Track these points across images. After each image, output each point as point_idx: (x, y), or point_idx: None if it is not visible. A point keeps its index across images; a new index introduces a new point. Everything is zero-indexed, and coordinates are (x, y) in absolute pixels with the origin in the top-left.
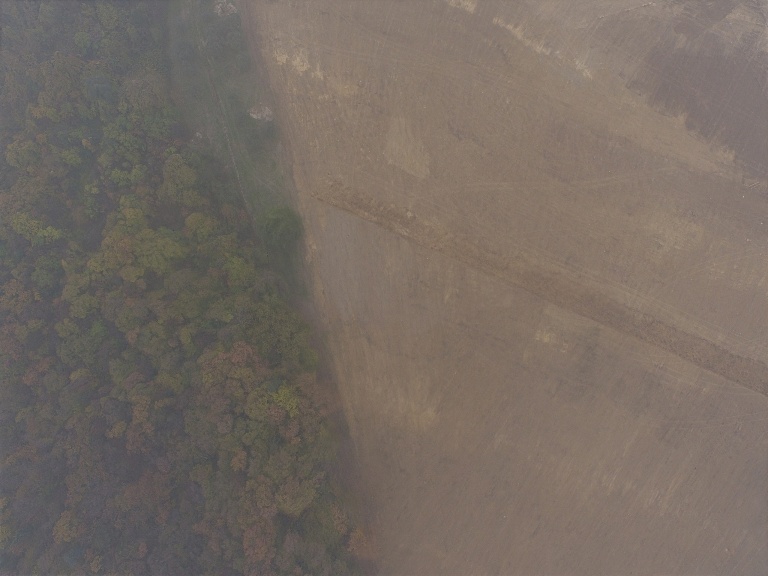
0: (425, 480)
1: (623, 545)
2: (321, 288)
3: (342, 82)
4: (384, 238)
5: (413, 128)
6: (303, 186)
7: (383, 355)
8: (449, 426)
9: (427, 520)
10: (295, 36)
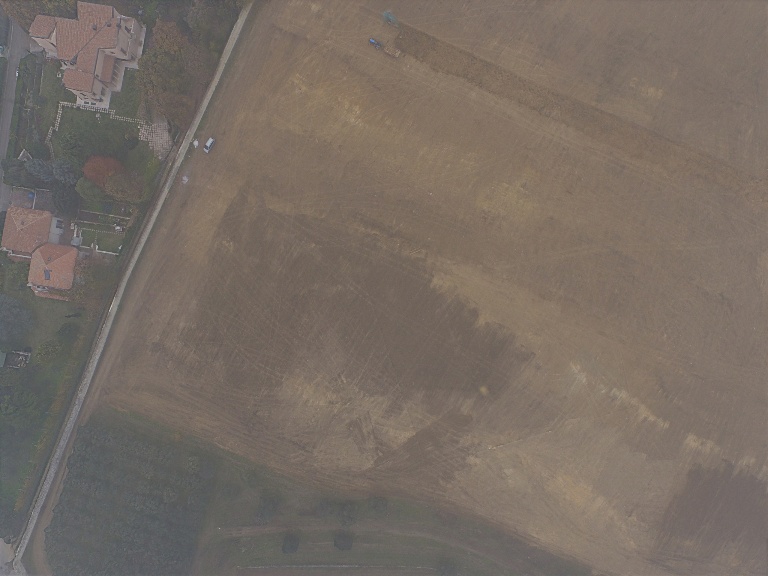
0: None
1: None
2: None
3: None
4: None
5: None
6: None
7: None
8: (761, 3)
9: None
10: None
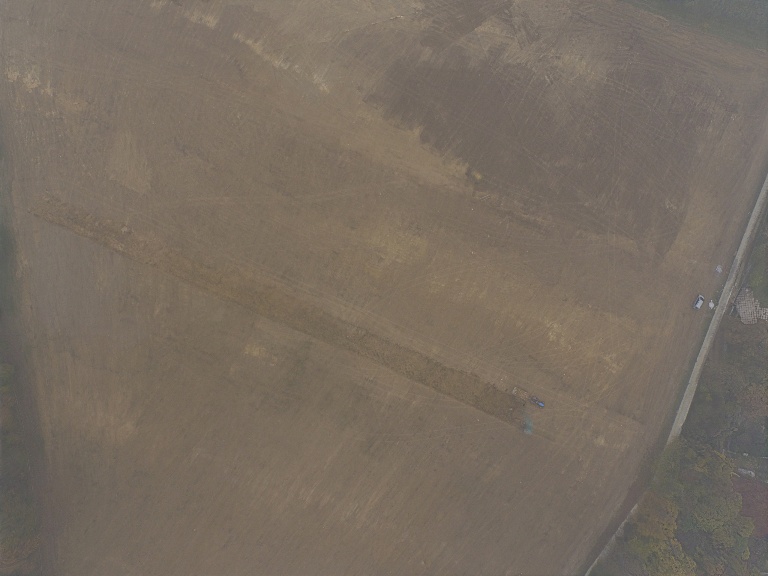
0: (117, 493)
1: (315, 558)
2: (29, 303)
3: (71, 99)
4: (98, 253)
5: (138, 144)
6: (20, 202)
7: (86, 369)
8: (147, 440)
9: (115, 533)
10: (29, 53)
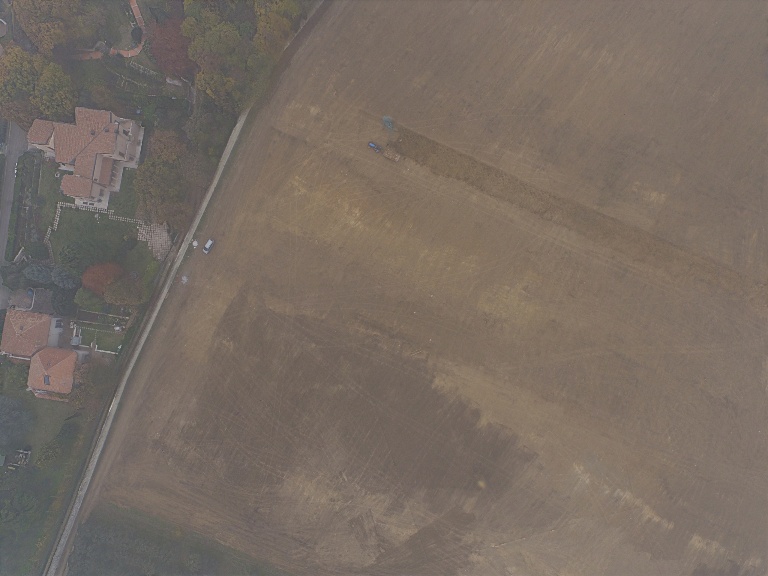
0: None
1: None
2: None
3: None
4: None
5: None
6: None
7: None
8: (764, 109)
9: None
10: None
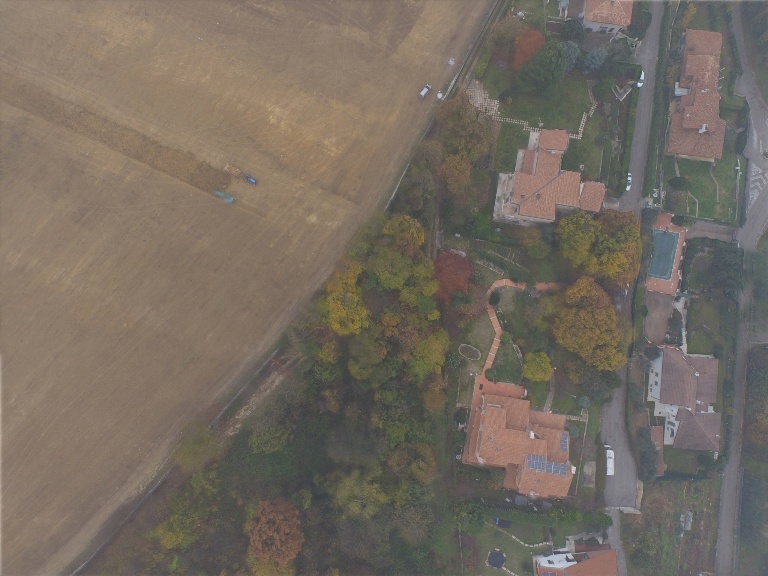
0: None
1: (17, 316)
2: None
3: None
4: None
5: None
6: None
7: None
8: None
9: None
10: None
